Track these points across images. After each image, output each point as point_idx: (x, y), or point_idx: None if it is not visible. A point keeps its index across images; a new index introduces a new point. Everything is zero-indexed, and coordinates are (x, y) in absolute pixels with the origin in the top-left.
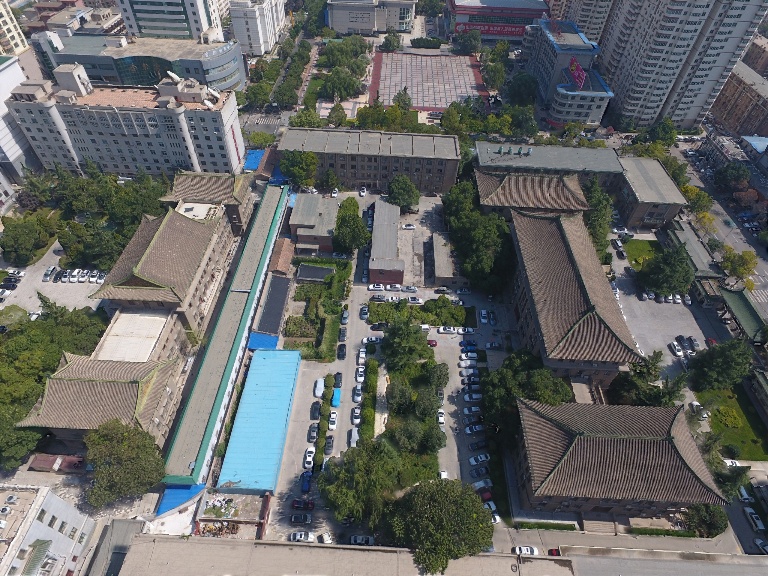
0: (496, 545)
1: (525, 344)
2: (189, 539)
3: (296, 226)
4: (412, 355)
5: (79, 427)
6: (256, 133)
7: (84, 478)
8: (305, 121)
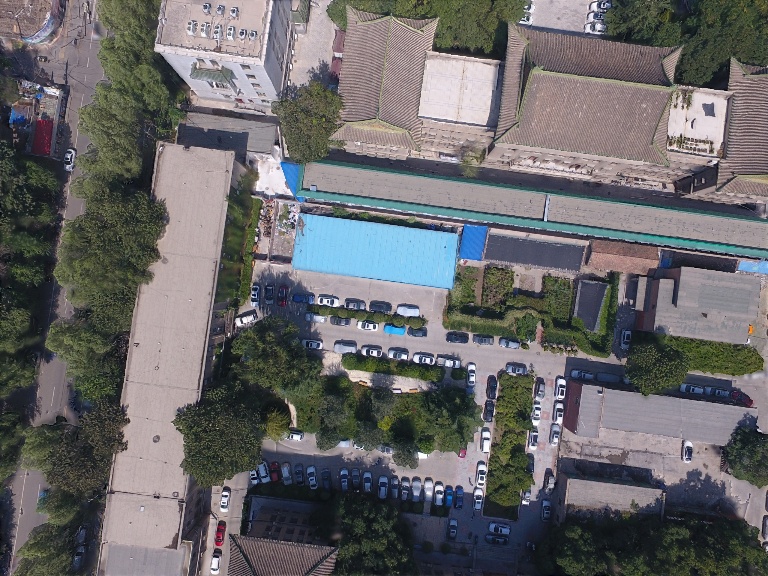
0: None
1: (444, 574)
2: (226, 202)
3: (678, 277)
4: (434, 427)
5: (342, 69)
6: None
7: (327, 84)
8: None
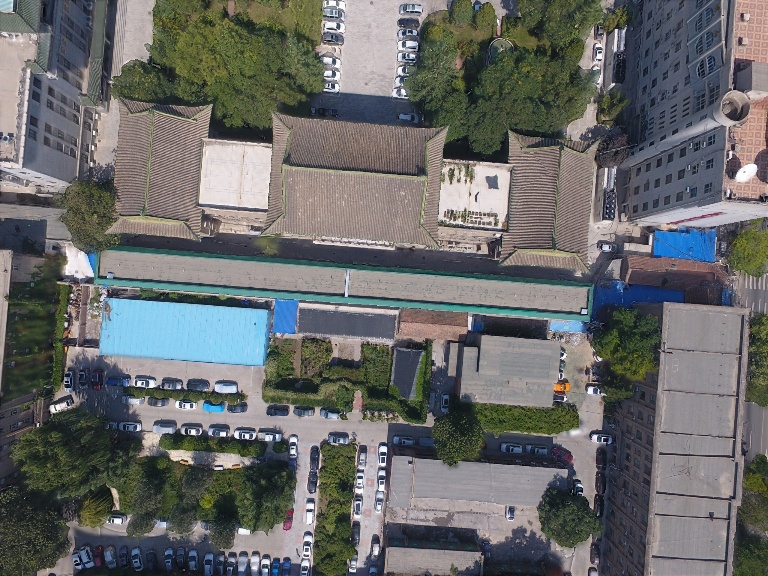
0: (58, 560)
1: None
2: (6, 302)
3: None
4: None
5: (116, 161)
6: (761, 241)
7: None
8: (764, 350)
